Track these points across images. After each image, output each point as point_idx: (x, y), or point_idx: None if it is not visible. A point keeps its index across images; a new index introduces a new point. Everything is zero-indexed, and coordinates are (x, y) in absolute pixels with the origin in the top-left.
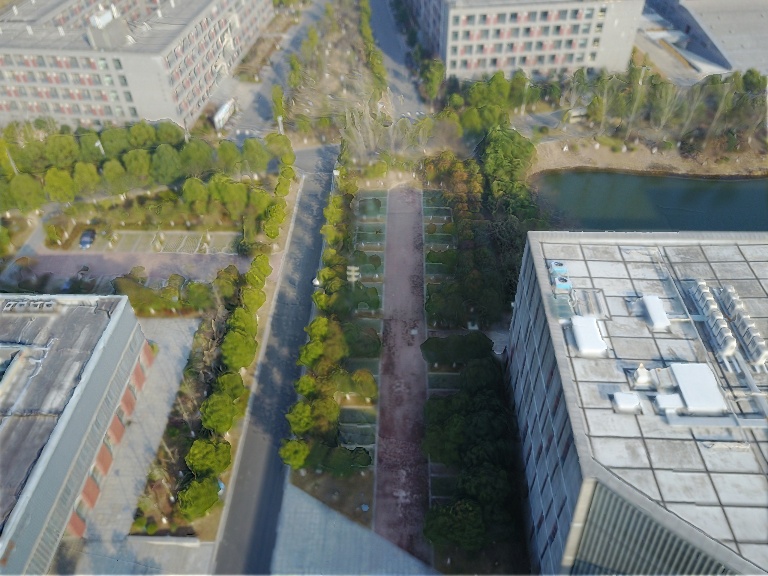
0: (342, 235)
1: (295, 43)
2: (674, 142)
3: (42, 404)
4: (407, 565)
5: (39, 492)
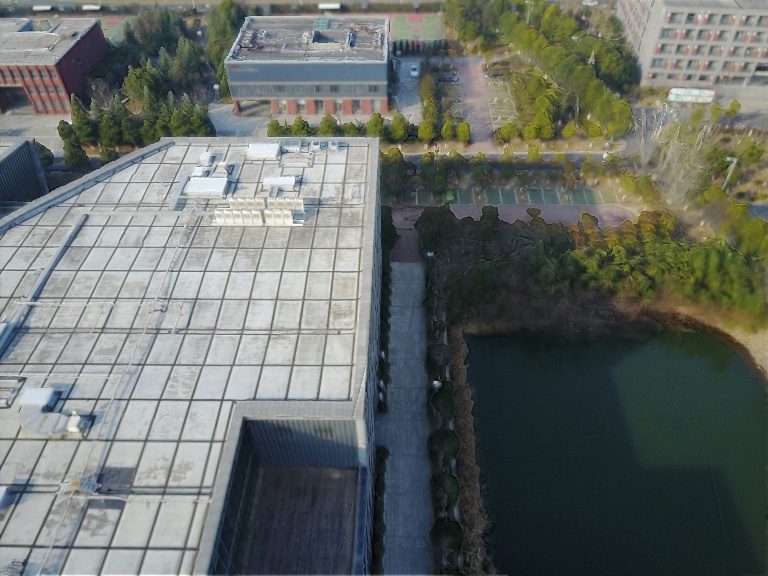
0: (505, 160)
1: None
2: None
3: (311, 57)
4: None
5: (263, 68)
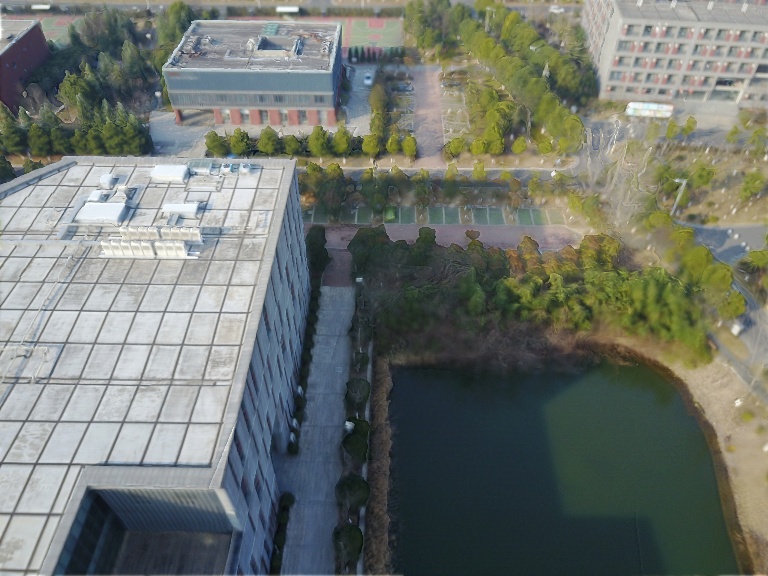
0: (448, 177)
1: None
2: None
3: (254, 65)
4: None
5: (203, 76)
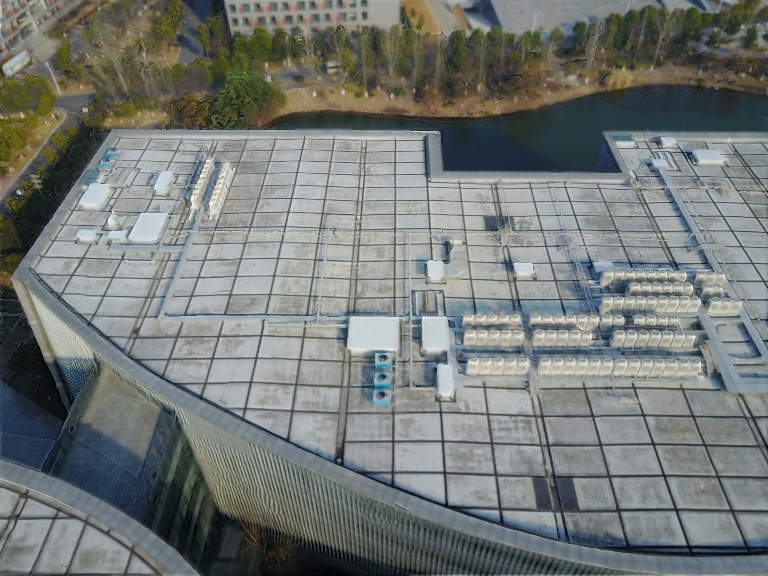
0: (59, 157)
1: (117, 6)
2: (410, 89)
3: None
4: (2, 393)
5: None
